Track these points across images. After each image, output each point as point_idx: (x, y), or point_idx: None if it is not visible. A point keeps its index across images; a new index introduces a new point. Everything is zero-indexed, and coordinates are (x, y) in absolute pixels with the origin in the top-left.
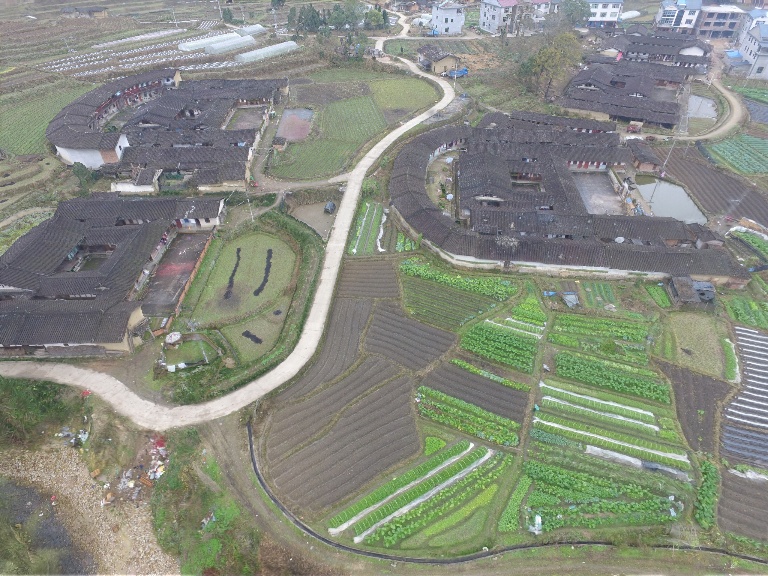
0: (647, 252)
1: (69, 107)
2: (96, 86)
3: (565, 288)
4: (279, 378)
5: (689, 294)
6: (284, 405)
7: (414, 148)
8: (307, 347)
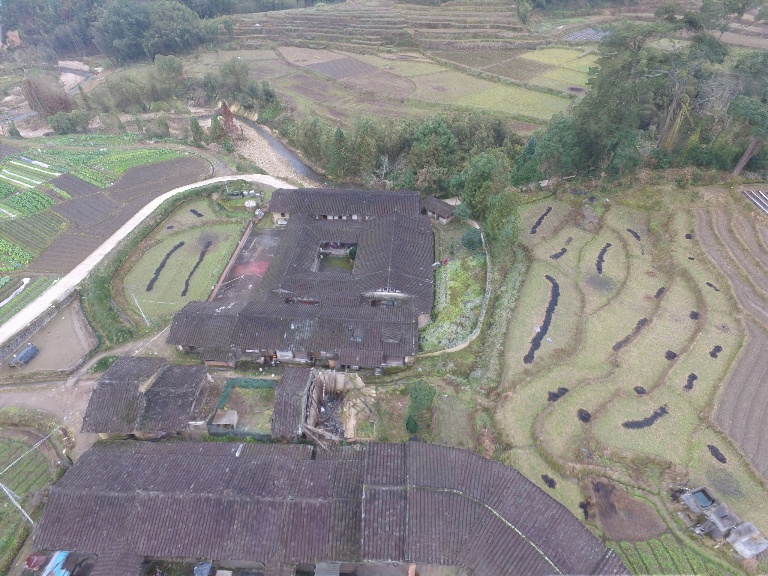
0: None
1: None
2: None
3: None
4: (186, 187)
5: None
6: None
7: None
8: (159, 200)
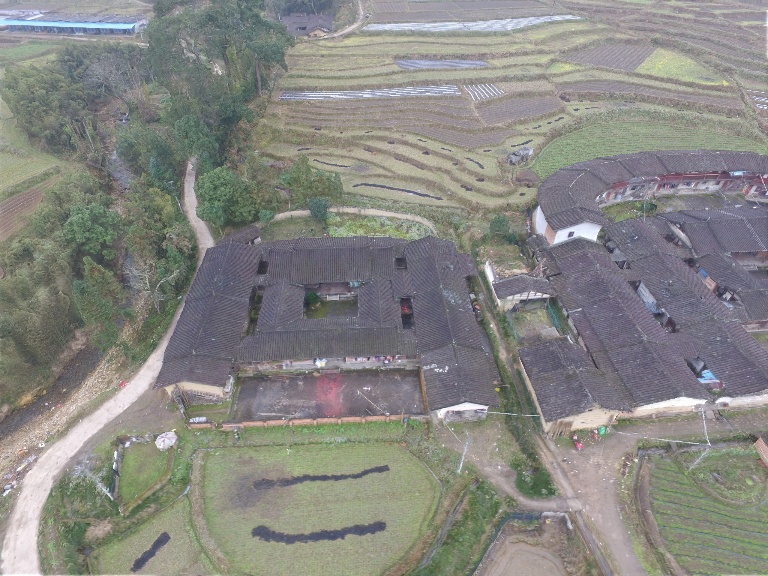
0: None
1: (645, 154)
2: (767, 147)
3: None
4: None
5: None
6: None
7: None
8: None
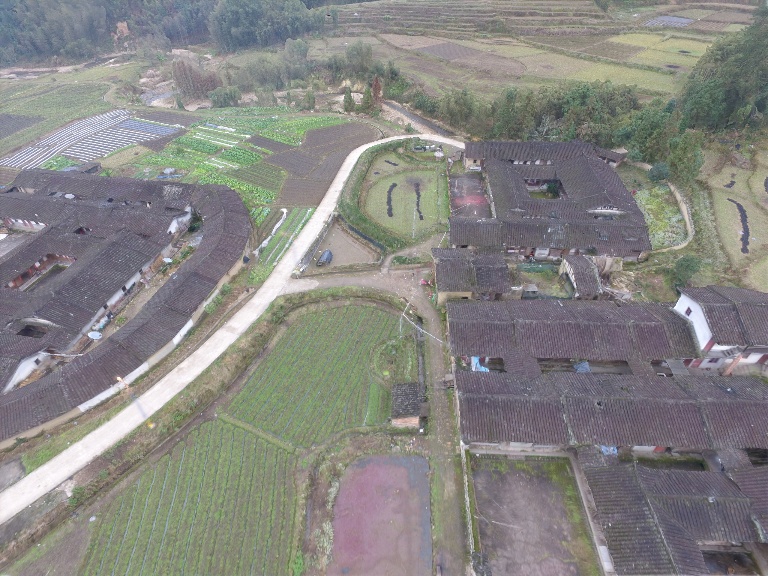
0: (75, 177)
1: None
2: None
3: (161, 180)
4: (371, 144)
5: (91, 164)
6: None
7: (150, 319)
8: (356, 153)
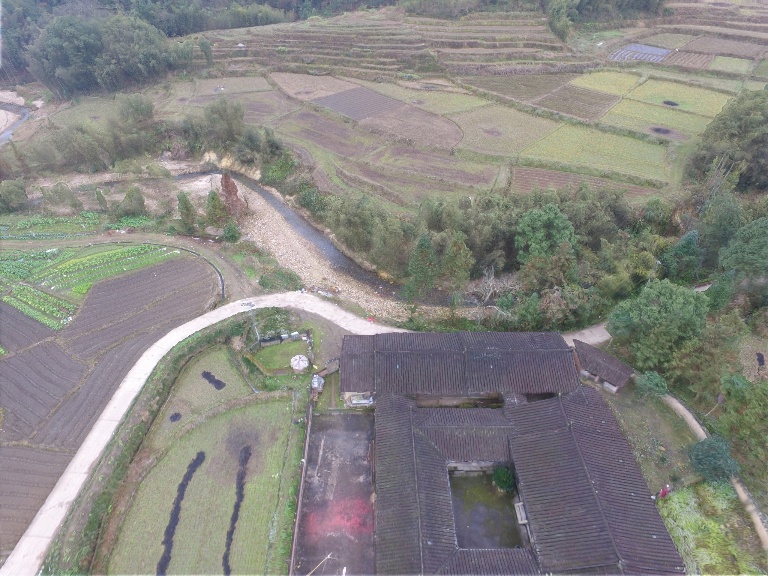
0: None
1: None
2: None
3: None
4: (189, 326)
5: None
6: (192, 315)
7: None
8: (150, 357)
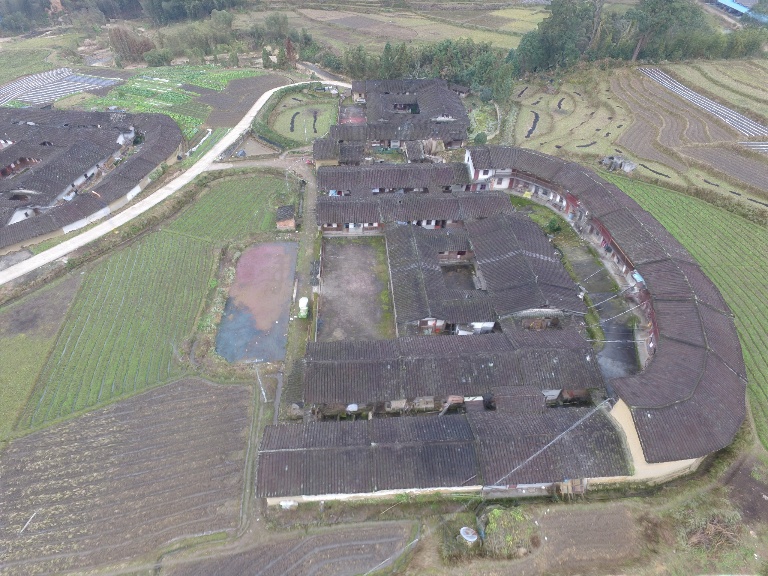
0: (33, 110)
1: None
2: None
3: None
4: (282, 87)
5: (44, 103)
6: None
7: (109, 181)
8: (269, 93)
